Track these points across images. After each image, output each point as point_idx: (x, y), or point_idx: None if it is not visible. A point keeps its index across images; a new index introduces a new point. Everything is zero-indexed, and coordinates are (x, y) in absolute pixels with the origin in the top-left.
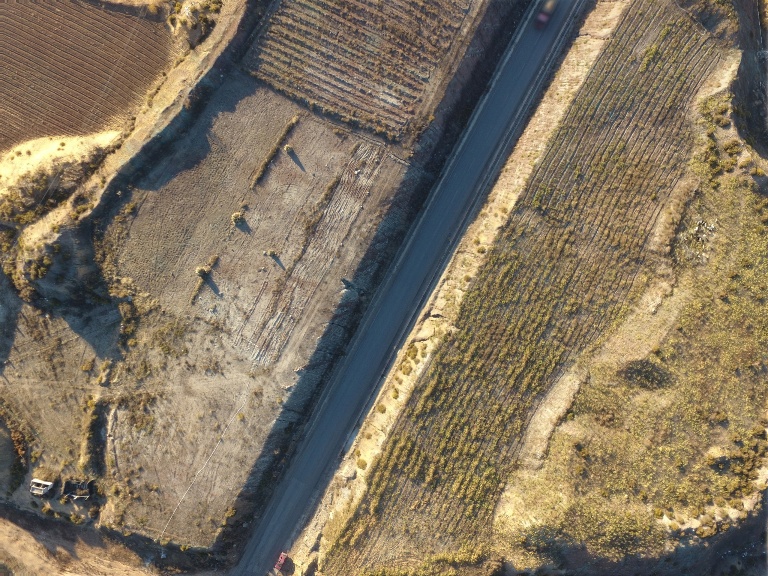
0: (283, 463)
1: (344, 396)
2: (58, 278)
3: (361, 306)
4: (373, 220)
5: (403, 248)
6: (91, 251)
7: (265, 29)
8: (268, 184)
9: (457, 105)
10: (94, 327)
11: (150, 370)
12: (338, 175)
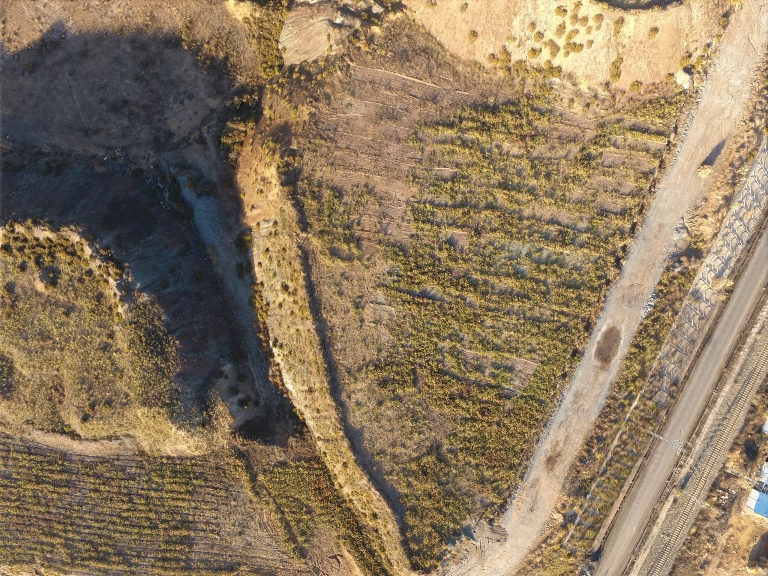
0: None
1: None
2: None
3: None
4: None
5: None
6: None
7: None
8: None
9: None
10: None
11: None
12: None
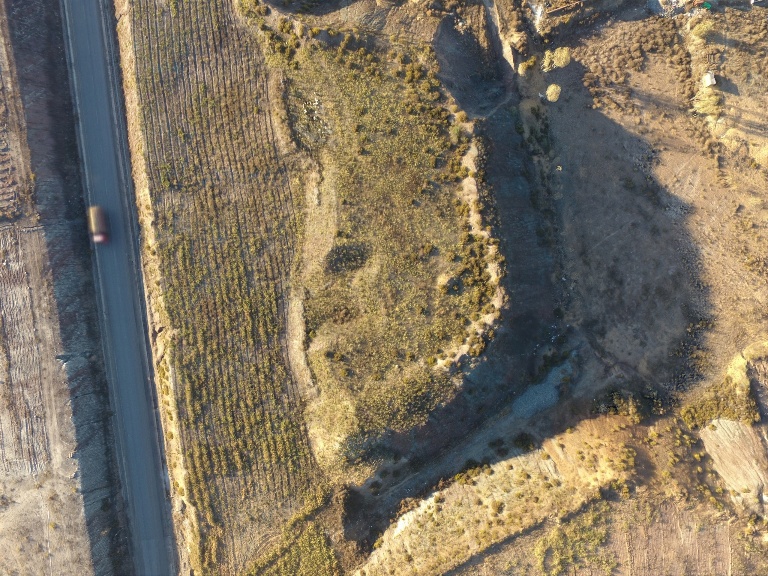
0: (124, 535)
1: (135, 447)
2: None
3: (97, 365)
4: (46, 292)
5: (99, 294)
6: None
7: None
8: None
9: (56, 149)
10: None
11: None
12: None
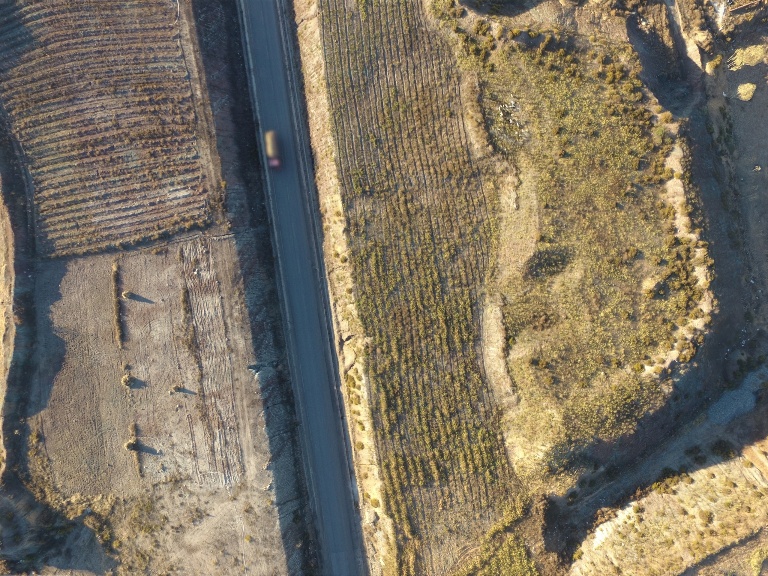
0: (313, 548)
1: (323, 457)
2: (15, 539)
3: (283, 375)
4: (238, 301)
5: (283, 303)
6: (29, 495)
7: (36, 213)
8: (132, 335)
9: (240, 156)
10: (78, 554)
11: (147, 555)
12: (182, 286)
